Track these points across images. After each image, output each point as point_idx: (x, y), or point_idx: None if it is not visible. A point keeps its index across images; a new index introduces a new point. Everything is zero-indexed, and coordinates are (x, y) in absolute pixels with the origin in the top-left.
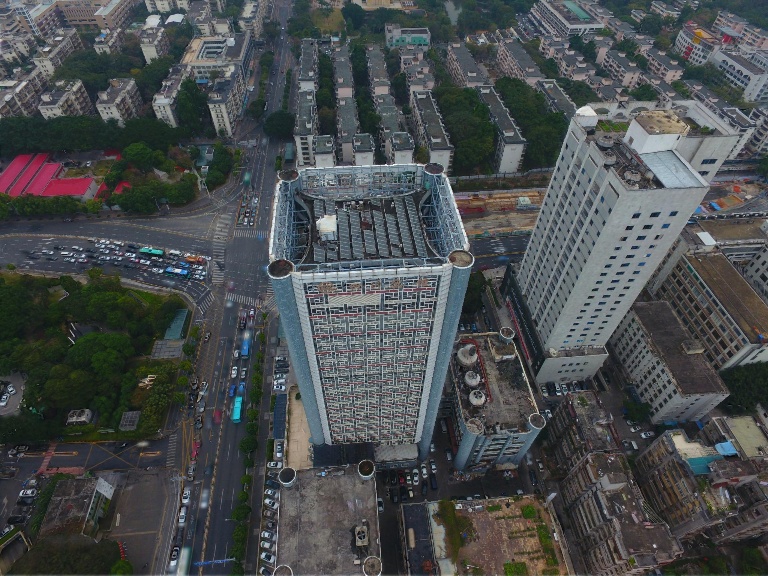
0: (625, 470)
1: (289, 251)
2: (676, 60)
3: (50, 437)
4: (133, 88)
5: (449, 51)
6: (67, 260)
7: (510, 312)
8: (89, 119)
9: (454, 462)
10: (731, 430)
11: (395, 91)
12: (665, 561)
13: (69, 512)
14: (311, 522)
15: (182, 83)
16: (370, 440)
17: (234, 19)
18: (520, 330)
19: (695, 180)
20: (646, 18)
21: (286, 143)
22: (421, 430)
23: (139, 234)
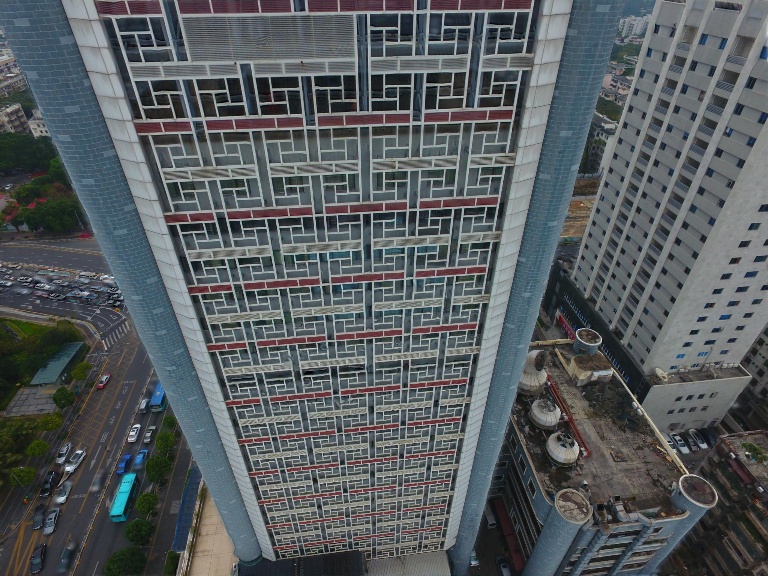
0: None
1: None
2: None
3: None
4: None
5: None
6: None
7: (565, 331)
8: (16, 136)
9: None
10: None
11: None
12: None
13: None
14: None
15: None
16: (355, 546)
17: None
18: None
19: None
20: None
21: None
22: (457, 520)
23: (46, 256)
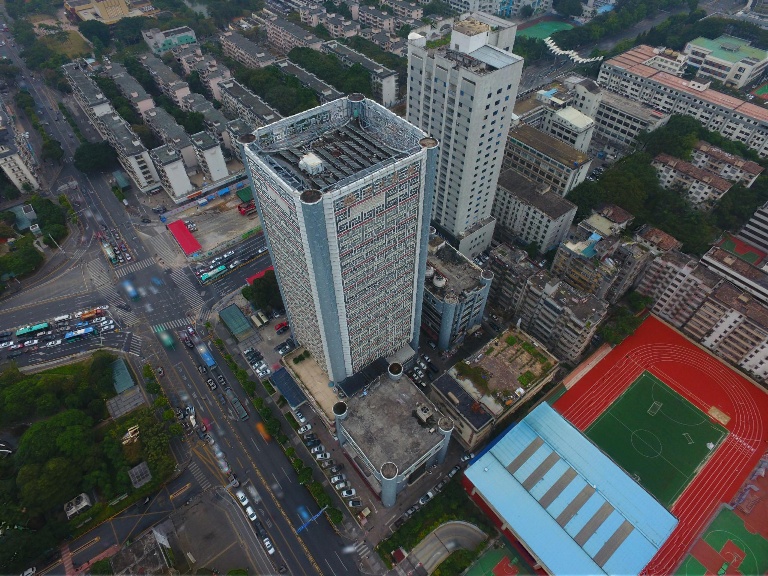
0: None
1: None
2: (413, 2)
3: (57, 541)
4: None
5: (223, 41)
6: None
7: None
8: None
9: (439, 346)
10: (592, 225)
11: (193, 91)
12: (604, 314)
13: (145, 574)
14: (380, 429)
15: None
16: (380, 355)
17: None
18: None
19: (512, 59)
20: None
21: (111, 173)
22: (413, 326)
23: None
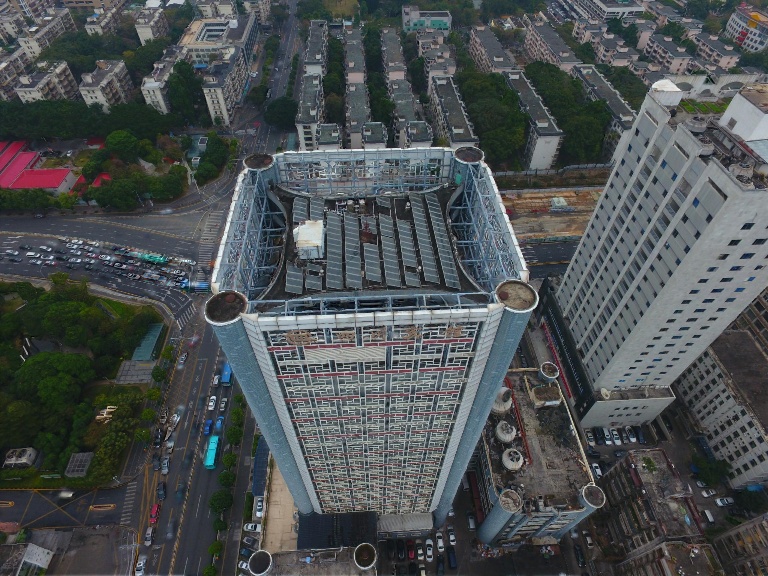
0: (715, 569)
1: (250, 274)
2: (731, 45)
3: None
4: (122, 71)
5: (472, 35)
6: (32, 262)
7: (546, 336)
8: (70, 104)
9: (478, 533)
10: None
11: (412, 78)
12: None
13: None
14: None
15: (175, 65)
16: (372, 509)
17: (239, 1)
18: (559, 360)
19: None
20: (691, 1)
21: (288, 133)
22: (438, 499)
23: (117, 233)
